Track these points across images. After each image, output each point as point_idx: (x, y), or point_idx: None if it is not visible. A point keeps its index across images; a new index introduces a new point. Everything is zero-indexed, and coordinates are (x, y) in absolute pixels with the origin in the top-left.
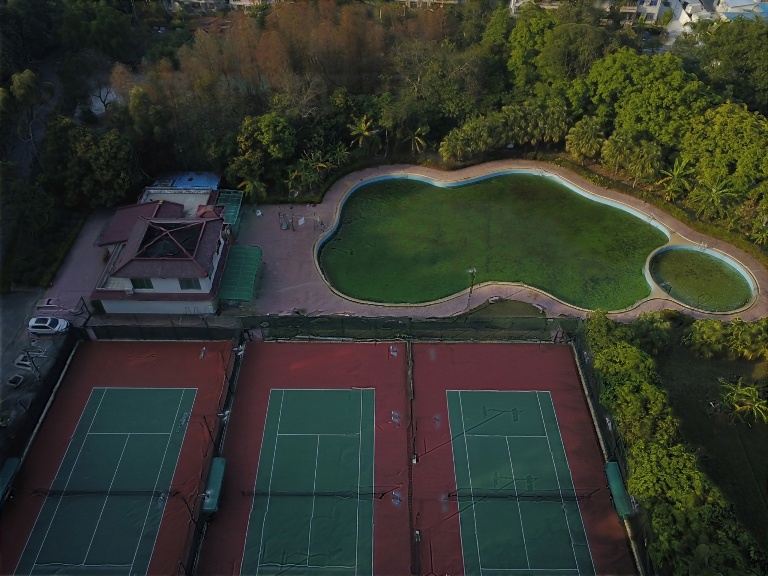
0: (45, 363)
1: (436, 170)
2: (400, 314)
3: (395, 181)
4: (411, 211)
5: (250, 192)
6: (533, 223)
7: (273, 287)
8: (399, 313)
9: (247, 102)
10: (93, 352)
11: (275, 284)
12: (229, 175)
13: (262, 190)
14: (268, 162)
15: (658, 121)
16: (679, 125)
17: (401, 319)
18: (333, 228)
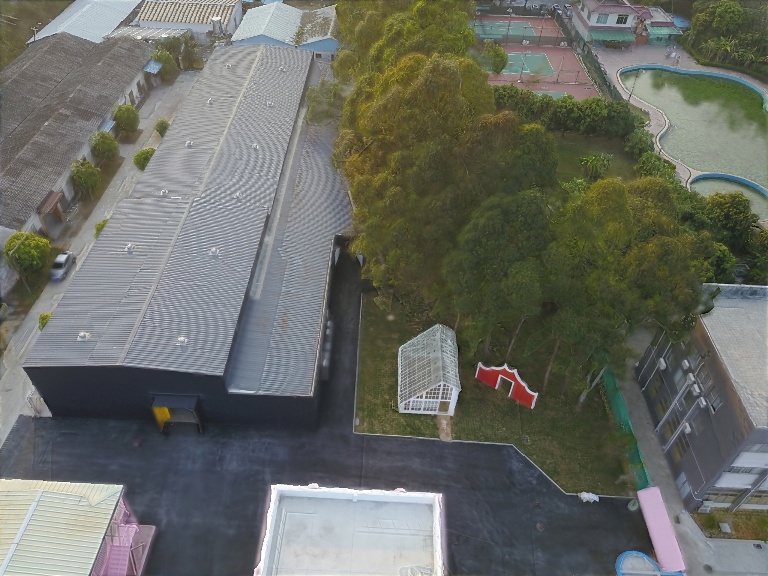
0: (535, 9)
1: None
2: (615, 85)
3: (755, 93)
4: (722, 96)
5: (684, 35)
6: (750, 141)
7: (614, 54)
8: (615, 84)
9: (753, 3)
10: (548, 21)
11: (617, 54)
12: None
13: (689, 39)
14: (710, 29)
15: None
16: None
17: None
18: (679, 69)
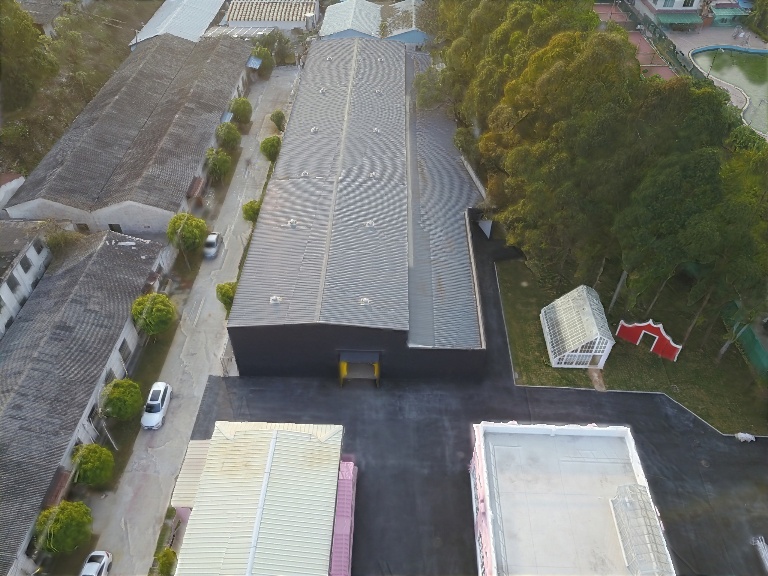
0: None
1: None
2: (689, 65)
3: None
4: None
5: (750, 16)
6: None
7: (682, 36)
8: (690, 65)
9: None
10: None
11: None
12: (755, 4)
13: (756, 19)
14: None
15: None
16: None
17: (673, 45)
18: (749, 48)
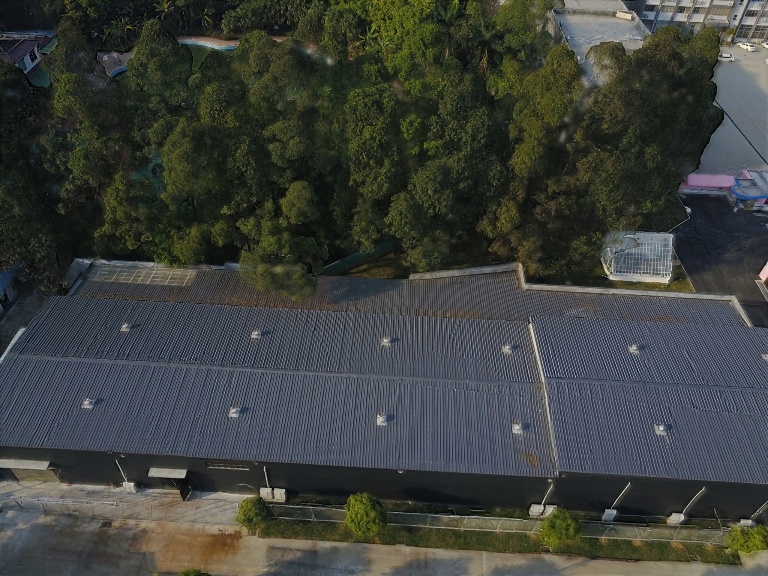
0: None
1: (219, 40)
2: None
3: None
4: None
5: None
6: None
7: None
8: None
9: None
10: None
11: None
12: None
13: None
14: (89, 21)
15: (354, 0)
16: (363, 1)
17: None
18: None
